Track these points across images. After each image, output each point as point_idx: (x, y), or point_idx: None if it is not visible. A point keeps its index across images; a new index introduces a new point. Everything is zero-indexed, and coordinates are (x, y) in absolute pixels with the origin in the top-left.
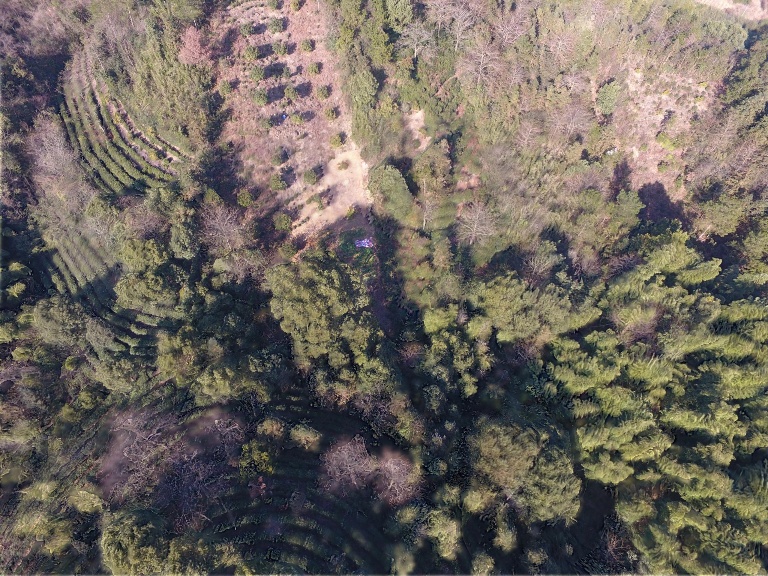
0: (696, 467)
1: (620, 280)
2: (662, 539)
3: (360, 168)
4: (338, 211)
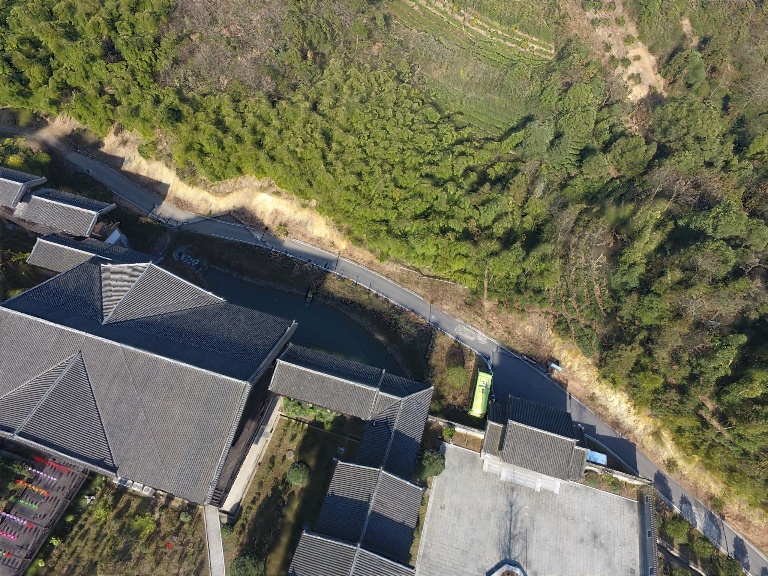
0: None
1: None
2: None
3: (648, 60)
4: (643, 88)
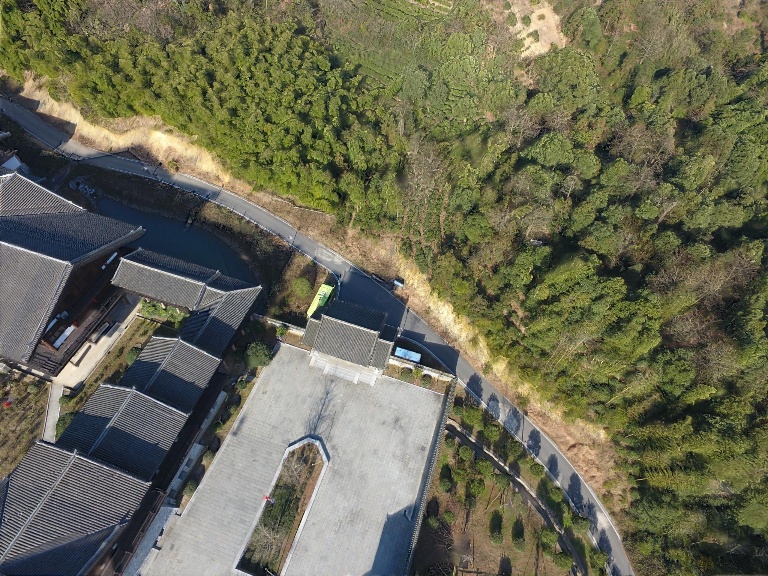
0: None
1: (749, 76)
2: None
3: (553, 19)
4: (544, 46)
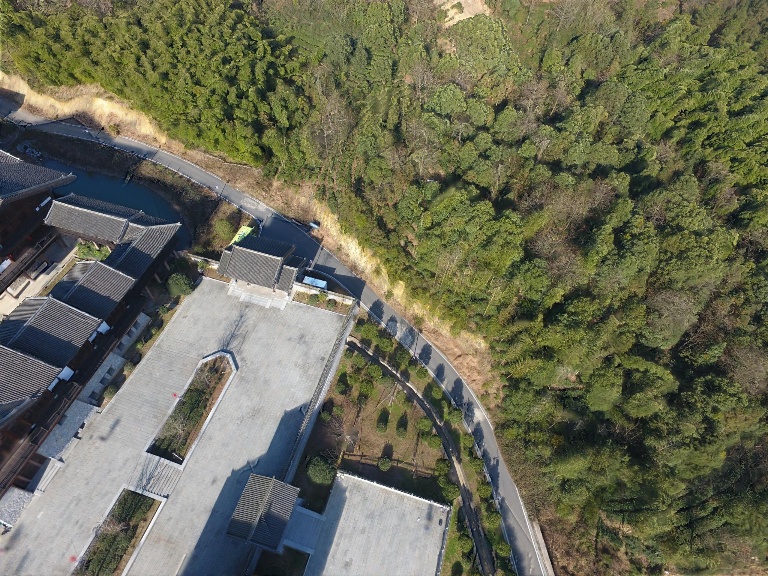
0: (709, 111)
1: (654, 40)
2: (695, 136)
3: None
4: None
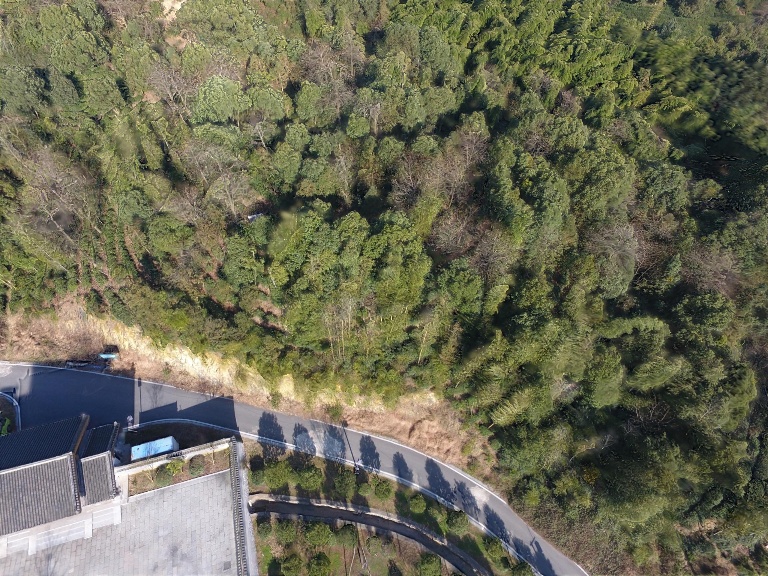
0: (496, 27)
1: None
2: (500, 55)
3: None
4: None
